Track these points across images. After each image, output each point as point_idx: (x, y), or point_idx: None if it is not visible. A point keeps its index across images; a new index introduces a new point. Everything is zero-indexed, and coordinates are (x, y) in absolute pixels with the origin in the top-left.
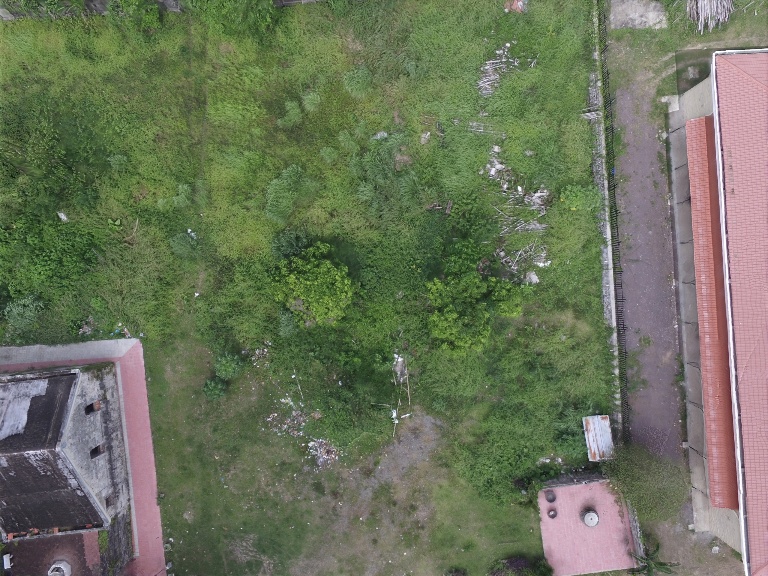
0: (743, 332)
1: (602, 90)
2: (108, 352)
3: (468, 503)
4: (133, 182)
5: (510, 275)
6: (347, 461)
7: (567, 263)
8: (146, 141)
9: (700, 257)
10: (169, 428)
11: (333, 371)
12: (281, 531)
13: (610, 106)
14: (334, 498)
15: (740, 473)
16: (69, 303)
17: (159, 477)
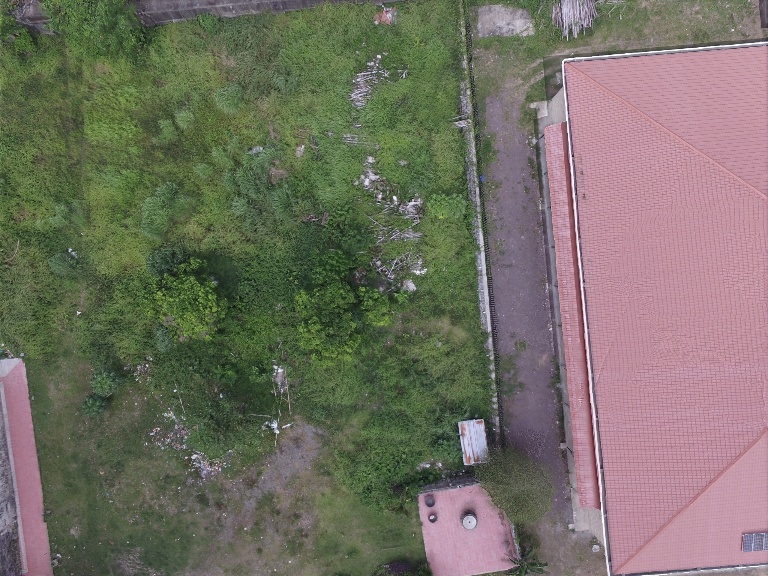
0: (598, 335)
1: (471, 98)
2: None
3: (351, 510)
4: (12, 204)
5: (387, 284)
6: (230, 472)
7: (443, 270)
8: (24, 163)
9: (561, 261)
10: (54, 445)
11: (214, 384)
12: (167, 543)
13: (477, 114)
14: (218, 509)
15: (599, 473)
16: None
17: (45, 494)
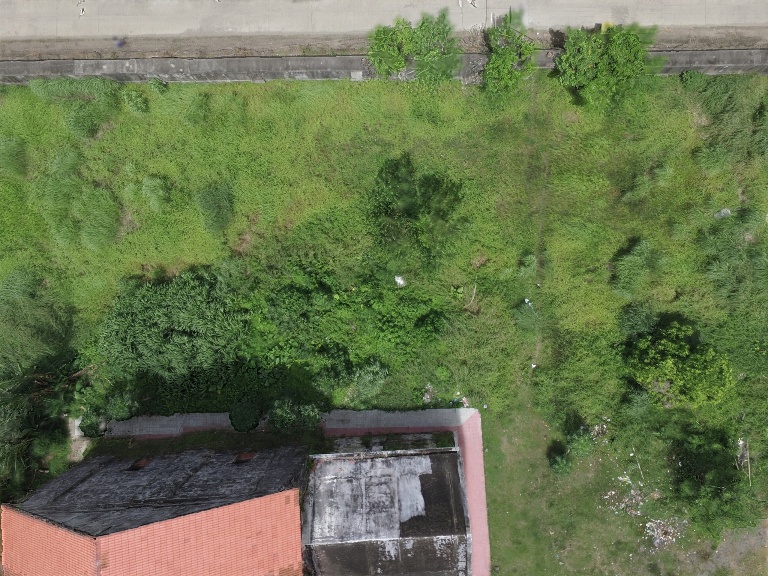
0: None
1: None
2: (446, 421)
3: None
4: (474, 249)
5: None
6: (684, 543)
7: None
8: (489, 209)
9: None
10: (504, 500)
11: (673, 451)
12: None
13: None
14: None
15: None
16: (414, 371)
17: (493, 550)
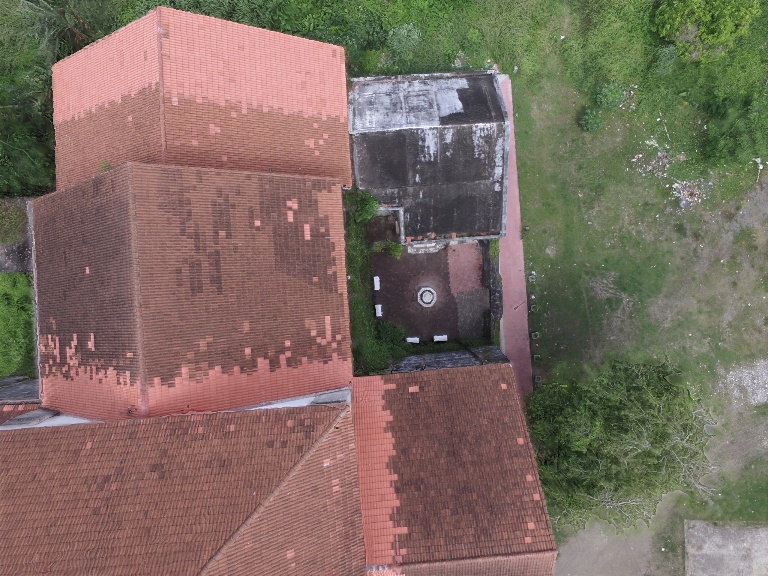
0: None
1: None
2: None
3: None
4: None
5: None
6: (710, 204)
7: None
8: None
9: None
10: (534, 164)
11: (699, 115)
12: (643, 269)
13: None
14: (695, 240)
15: None
16: (446, 33)
17: (523, 211)
